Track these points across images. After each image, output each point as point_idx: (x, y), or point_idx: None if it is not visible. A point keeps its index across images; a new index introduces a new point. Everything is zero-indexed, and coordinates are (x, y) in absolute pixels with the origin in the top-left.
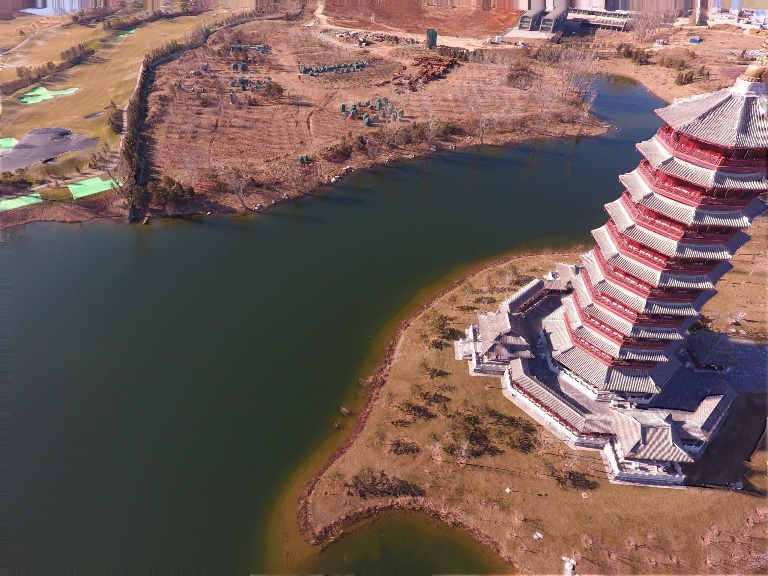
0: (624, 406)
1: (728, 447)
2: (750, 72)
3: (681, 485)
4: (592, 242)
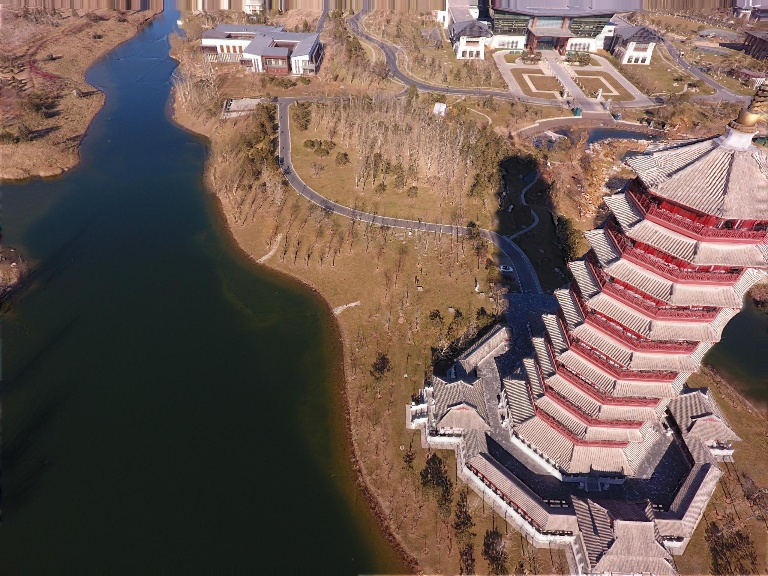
0: None
1: None
2: None
3: None
4: (315, 367)
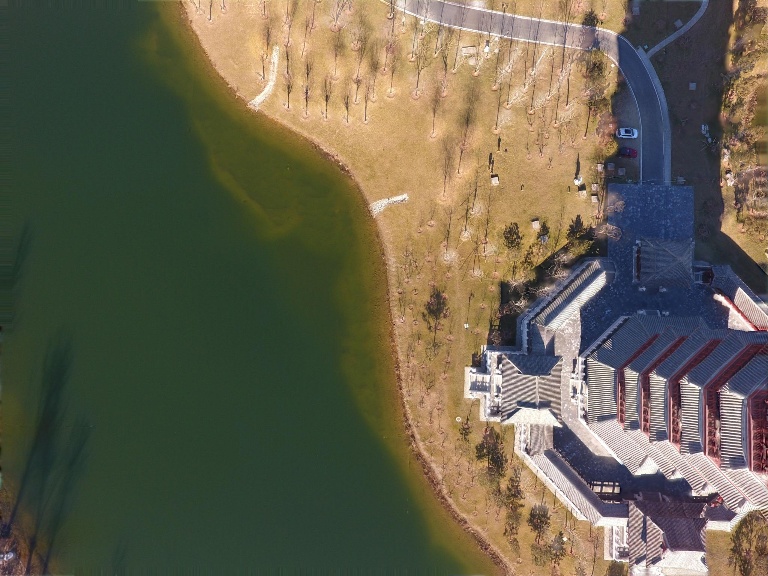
0: None
1: (759, 292)
2: None
3: None
4: (354, 298)
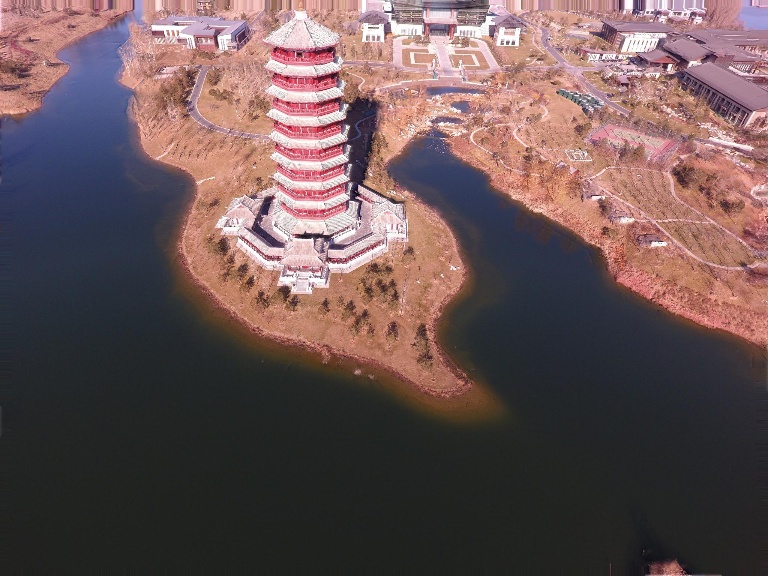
0: (359, 223)
1: None
2: (302, 5)
3: (406, 220)
4: (174, 208)
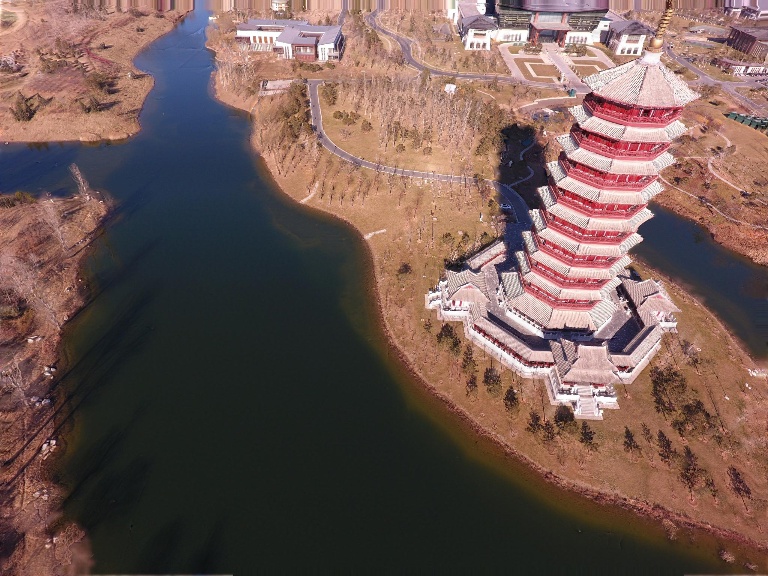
0: None
1: None
2: None
3: None
4: (351, 274)
